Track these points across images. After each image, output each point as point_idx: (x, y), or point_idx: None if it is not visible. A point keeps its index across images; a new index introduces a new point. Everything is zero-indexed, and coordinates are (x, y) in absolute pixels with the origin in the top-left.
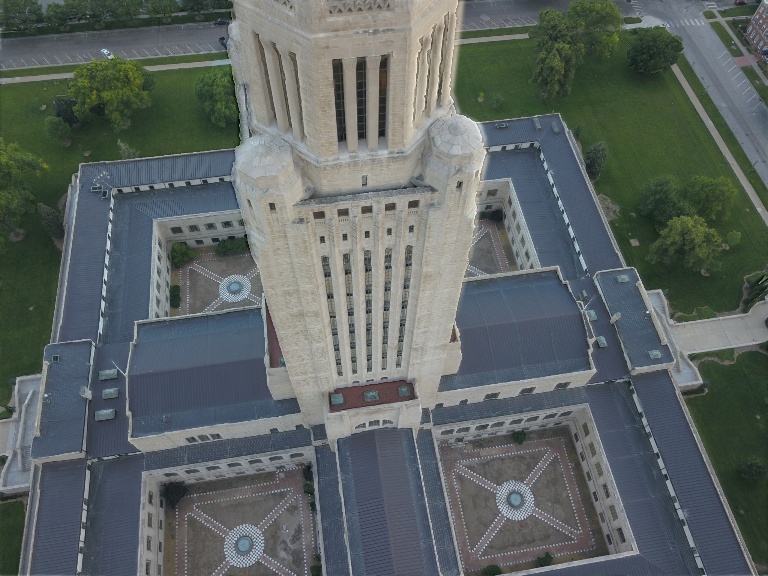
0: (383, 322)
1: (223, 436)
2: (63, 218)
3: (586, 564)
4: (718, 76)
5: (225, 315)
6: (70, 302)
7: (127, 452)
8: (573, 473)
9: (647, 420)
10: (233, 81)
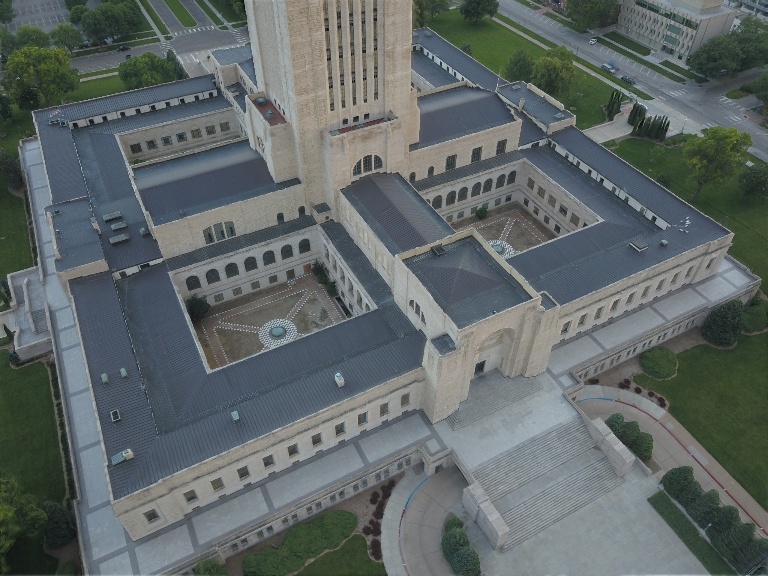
0: (361, 12)
1: (236, 229)
2: (20, 166)
3: (569, 235)
4: (529, 20)
5: (210, 151)
6: (55, 187)
7: (149, 259)
8: (534, 226)
9: (572, 154)
10: (153, 60)
